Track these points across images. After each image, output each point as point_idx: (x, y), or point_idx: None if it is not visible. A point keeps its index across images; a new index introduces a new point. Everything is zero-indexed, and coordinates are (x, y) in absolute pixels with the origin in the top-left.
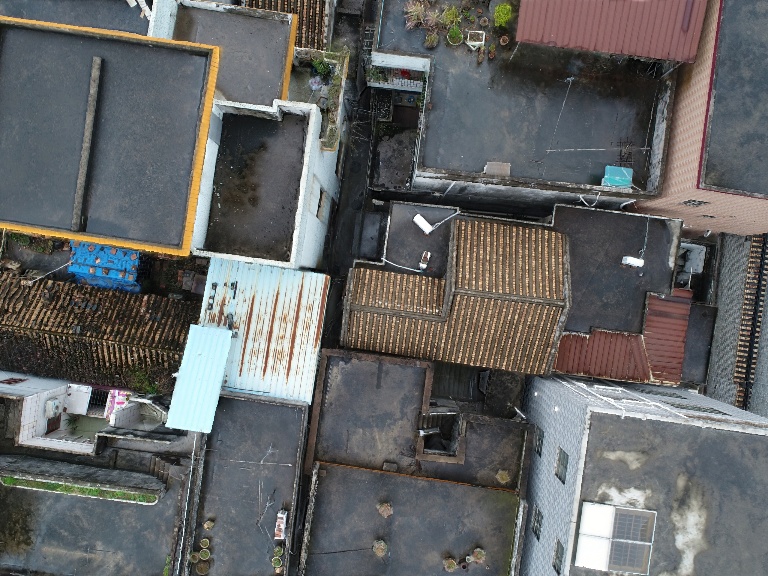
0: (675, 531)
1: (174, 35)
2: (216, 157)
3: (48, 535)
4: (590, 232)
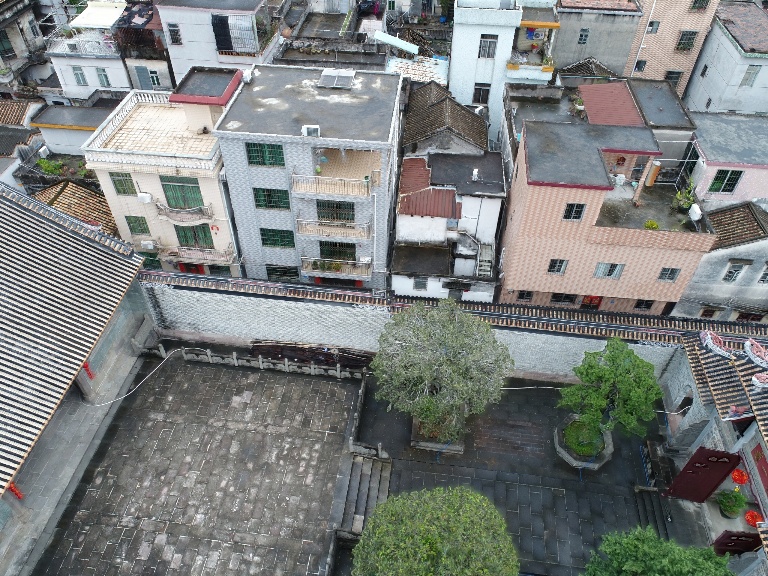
0: (340, 95)
1: (540, 8)
2: (495, 8)
3: (324, 24)
4: (489, 165)
